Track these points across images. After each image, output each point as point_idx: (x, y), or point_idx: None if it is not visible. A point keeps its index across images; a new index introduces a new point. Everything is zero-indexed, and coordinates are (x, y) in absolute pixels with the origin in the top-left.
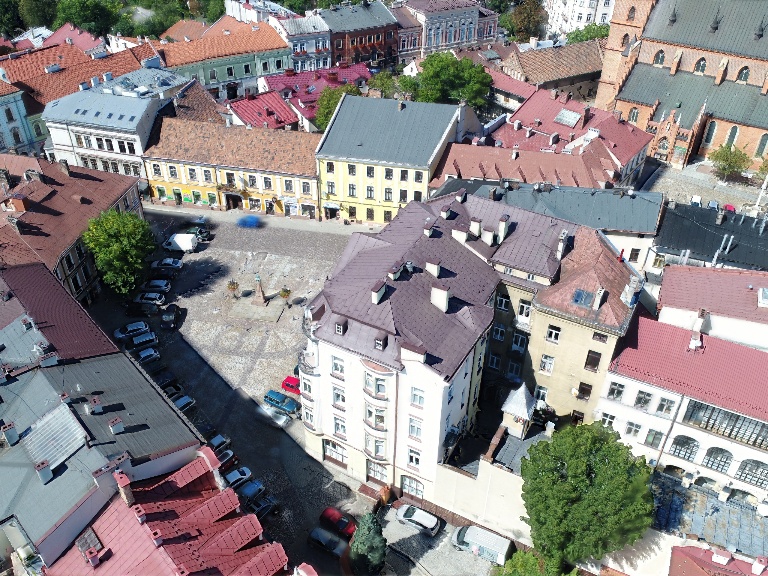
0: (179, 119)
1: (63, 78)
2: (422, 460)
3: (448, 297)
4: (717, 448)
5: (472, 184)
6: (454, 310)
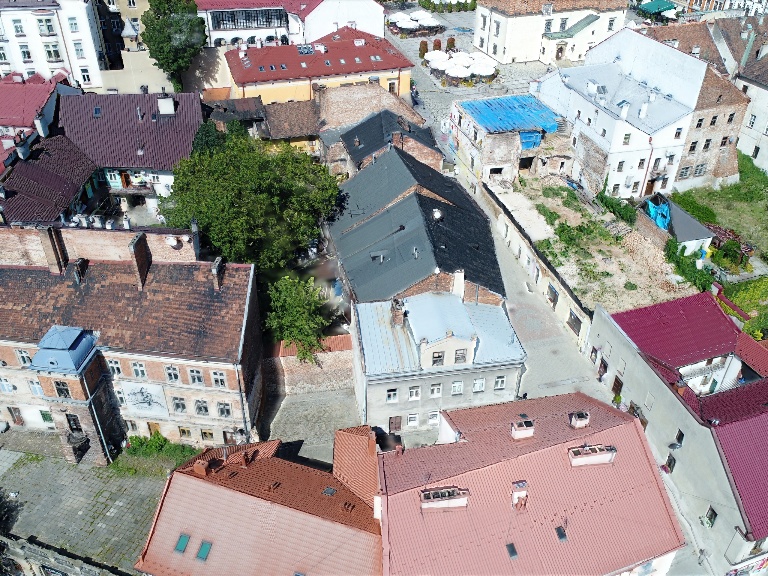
0: None
1: None
2: (91, 74)
3: None
4: (234, 38)
5: None
6: None
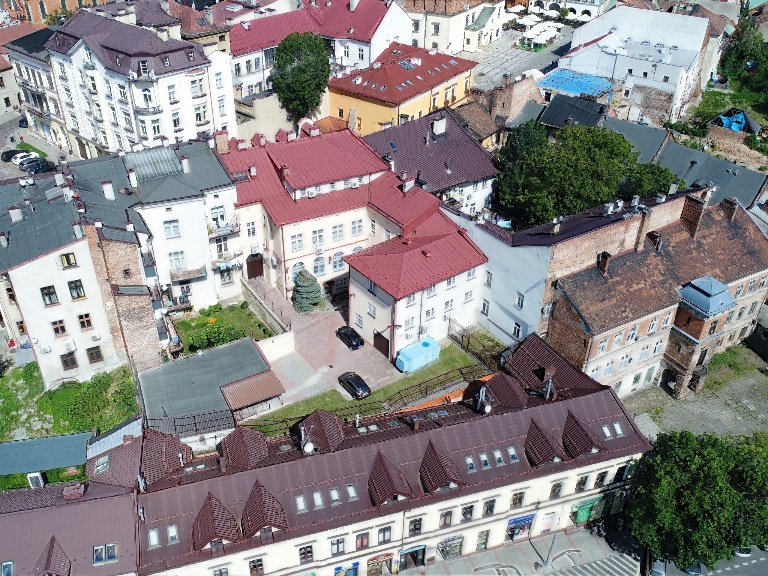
0: None
1: None
2: None
3: None
4: None
5: (37, 32)
6: None
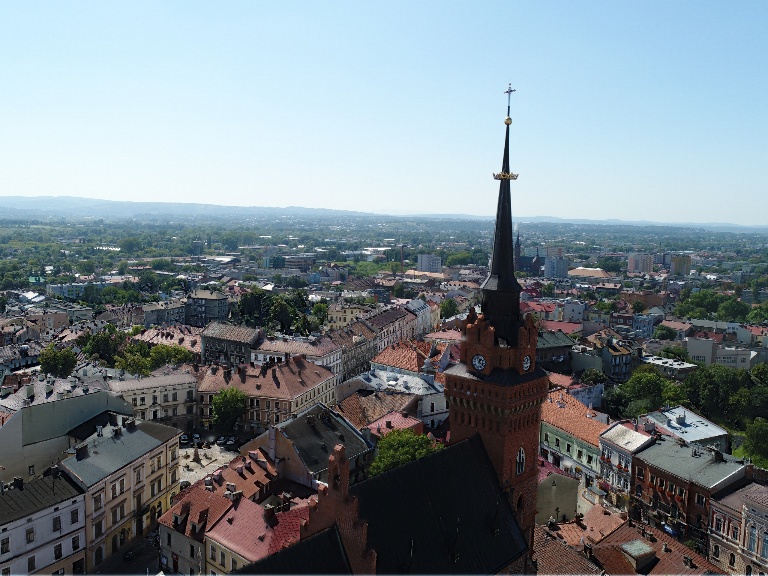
0: (351, 395)
1: None
2: None
3: (27, 391)
4: None
5: None
6: None
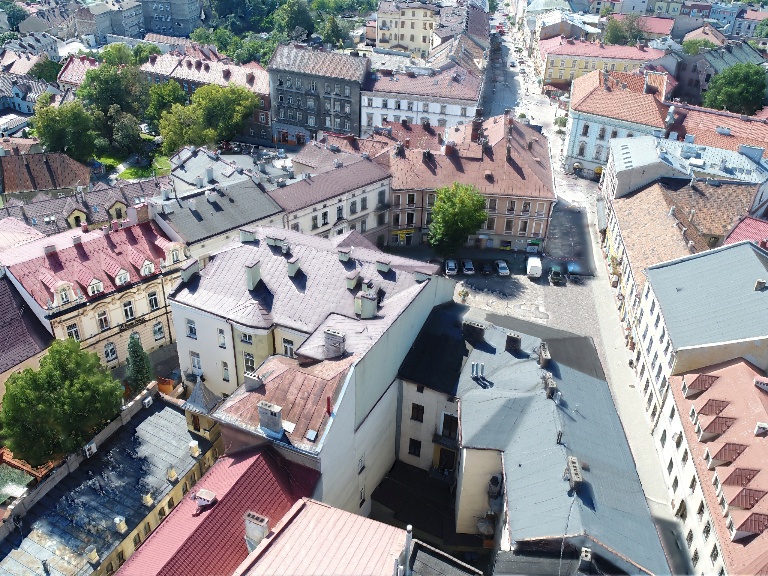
0: (661, 190)
1: (723, 142)
2: None
3: (252, 277)
4: None
5: None
6: (257, 297)
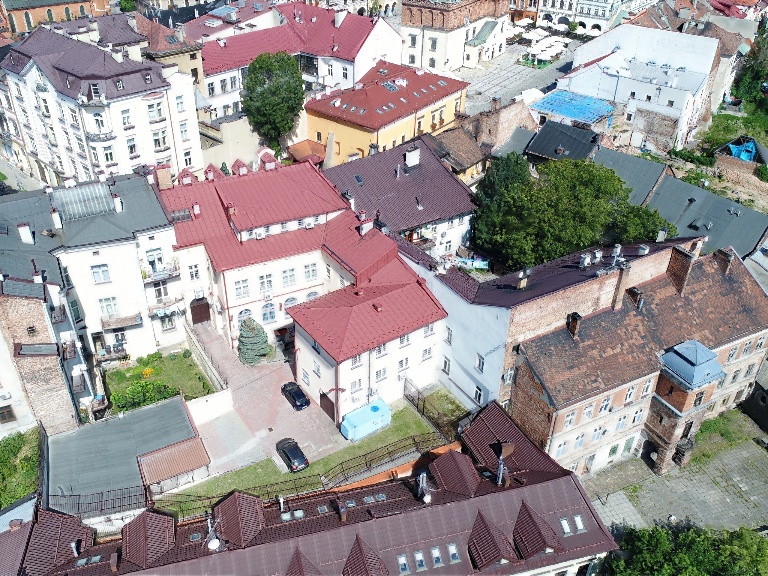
0: None
1: None
2: (193, 156)
3: None
4: None
5: None
6: None
